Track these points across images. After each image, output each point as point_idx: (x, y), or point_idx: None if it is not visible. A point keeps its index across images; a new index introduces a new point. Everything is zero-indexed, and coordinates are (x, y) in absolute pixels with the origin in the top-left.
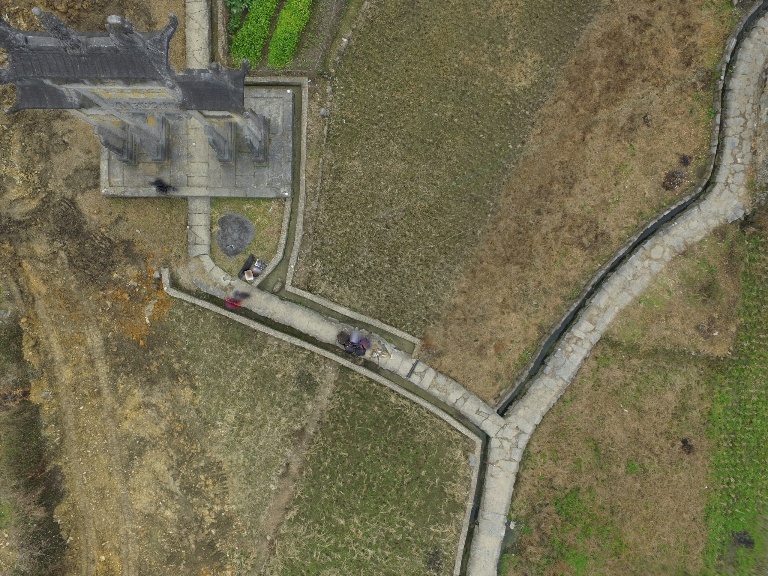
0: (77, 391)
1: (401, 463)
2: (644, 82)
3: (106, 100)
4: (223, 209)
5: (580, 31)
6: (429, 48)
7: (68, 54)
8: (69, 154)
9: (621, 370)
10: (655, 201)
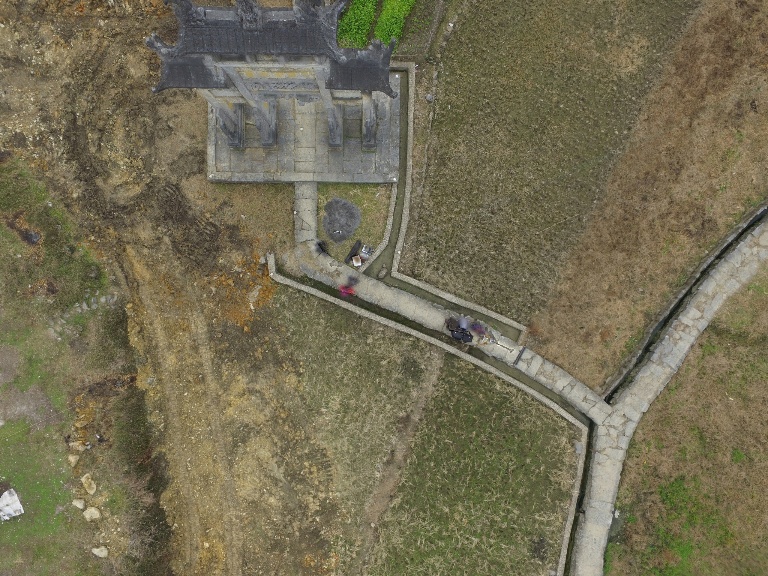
0: (181, 377)
1: (506, 451)
2: (751, 68)
3: (245, 80)
4: (330, 194)
5: (687, 16)
6: (535, 33)
7: (242, 29)
8: (174, 139)
9: (726, 358)
10: (762, 188)
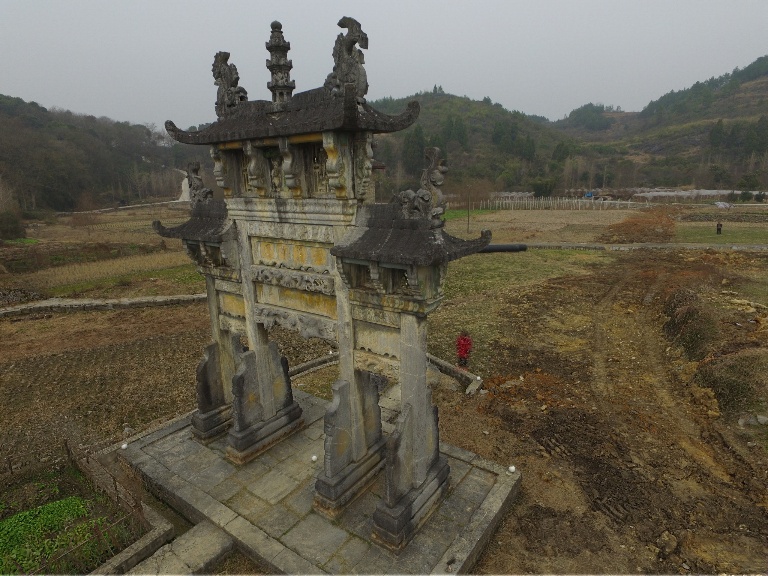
0: None
1: None
2: None
3: None
4: None
5: None
6: None
7: None
8: None
9: None
10: None
